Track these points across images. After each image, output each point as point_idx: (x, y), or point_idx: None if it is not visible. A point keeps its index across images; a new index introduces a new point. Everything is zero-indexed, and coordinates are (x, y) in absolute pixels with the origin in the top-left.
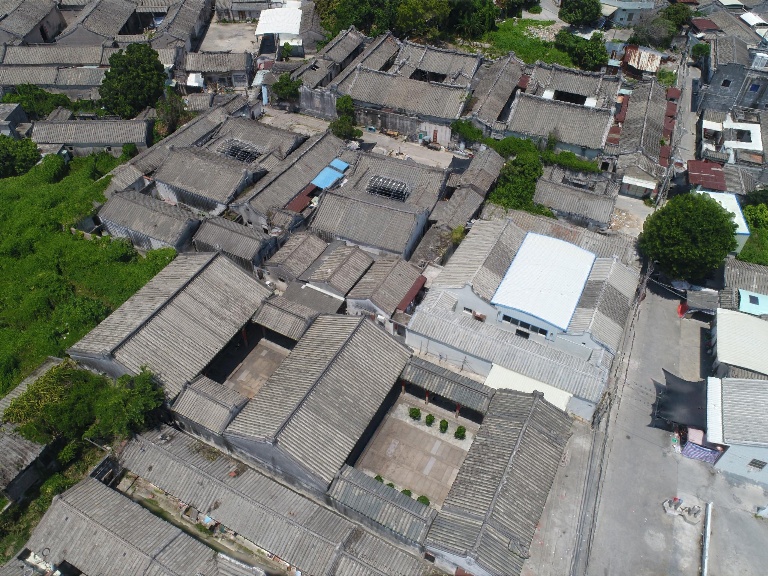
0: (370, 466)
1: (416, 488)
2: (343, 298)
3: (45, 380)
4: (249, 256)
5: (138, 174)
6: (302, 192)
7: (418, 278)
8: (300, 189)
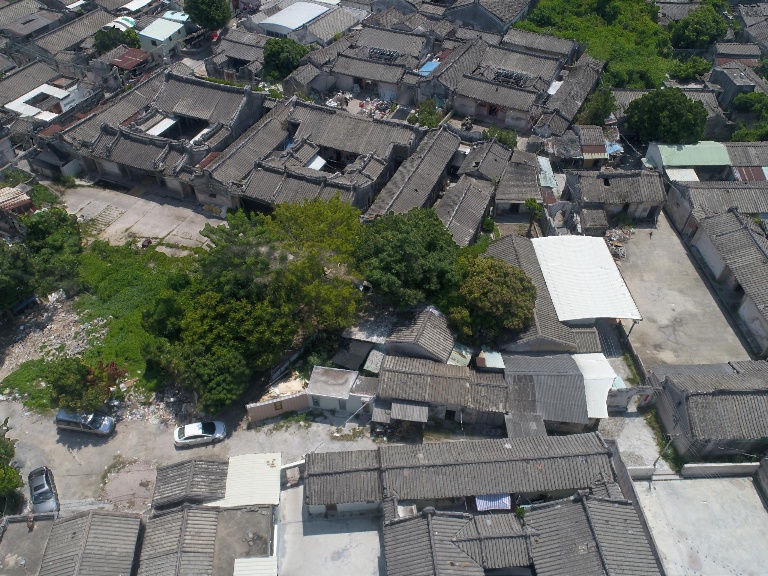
0: None
1: None
2: None
3: None
4: None
5: None
6: None
7: None
8: None
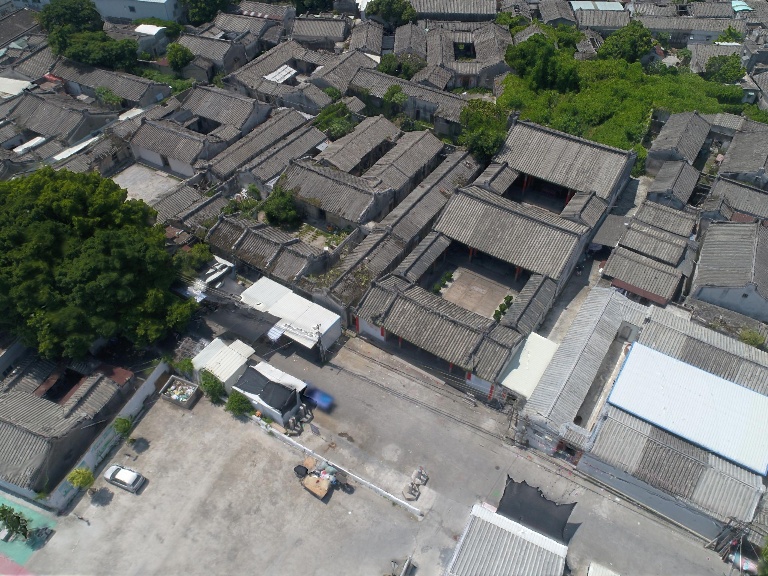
0: (463, 276)
1: None
2: None
3: (495, 105)
4: (652, 190)
5: (737, 126)
6: None
7: (661, 296)
8: None
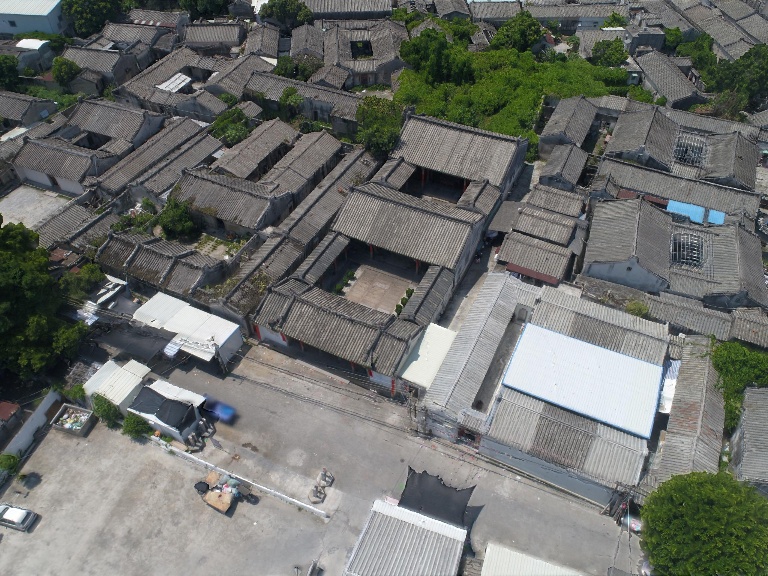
0: (366, 274)
1: (348, 299)
2: None
3: (389, 101)
4: (543, 174)
5: (621, 107)
6: (651, 196)
7: (553, 277)
8: (652, 192)
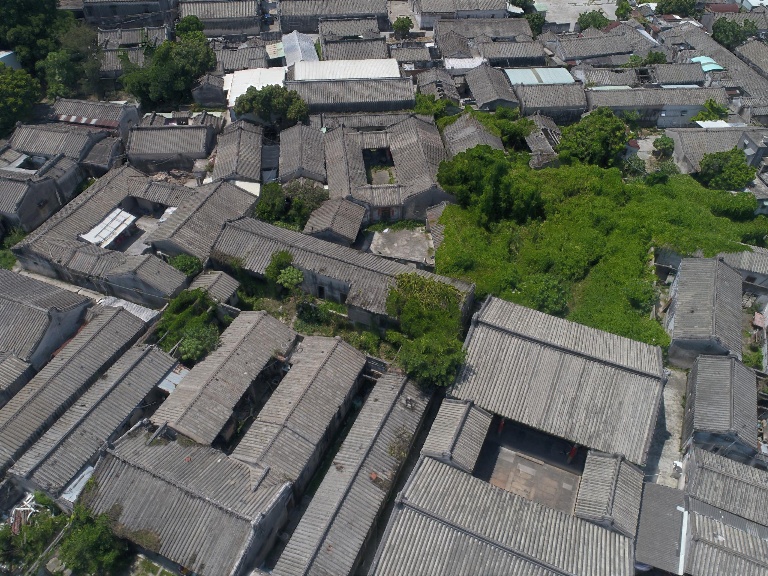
0: None
1: None
2: (682, 572)
3: (438, 286)
4: (700, 424)
5: None
6: None
7: None
8: None
